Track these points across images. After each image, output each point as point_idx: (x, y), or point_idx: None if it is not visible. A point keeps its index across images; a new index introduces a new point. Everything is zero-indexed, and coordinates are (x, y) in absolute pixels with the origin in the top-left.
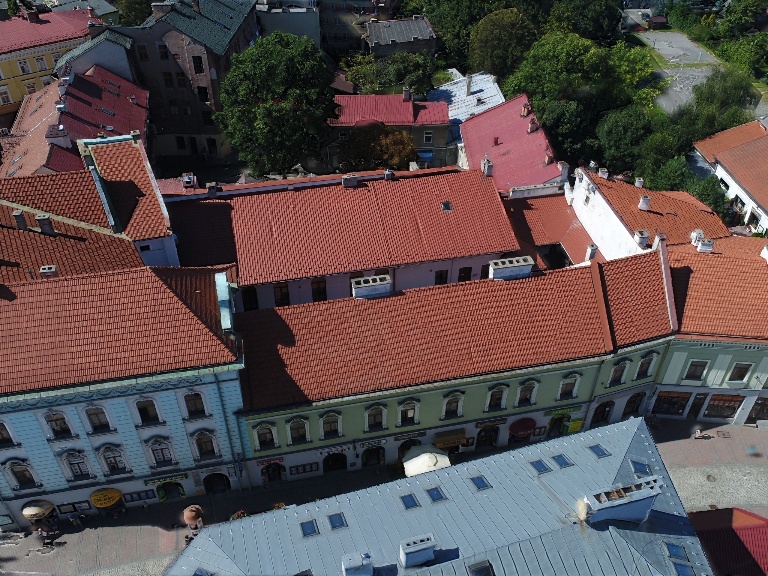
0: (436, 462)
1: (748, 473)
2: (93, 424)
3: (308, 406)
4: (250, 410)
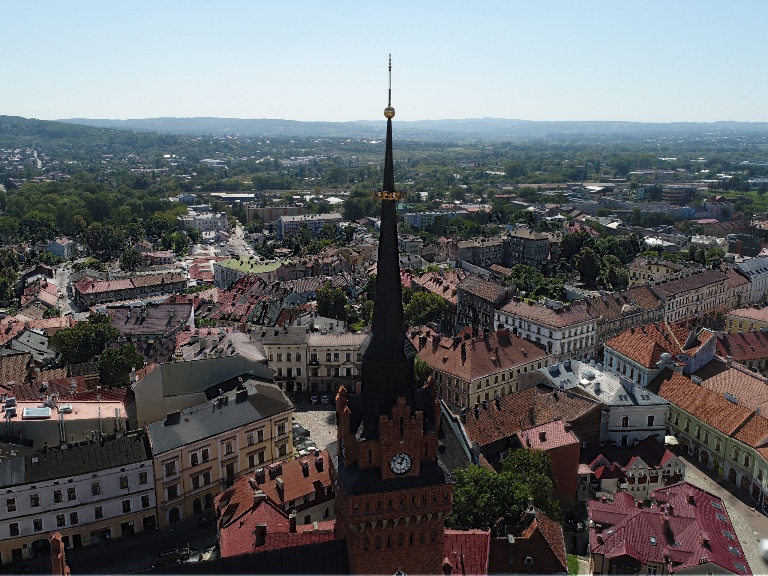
0: (672, 439)
1: (740, 517)
2: (624, 371)
3: (656, 395)
4: (647, 387)
